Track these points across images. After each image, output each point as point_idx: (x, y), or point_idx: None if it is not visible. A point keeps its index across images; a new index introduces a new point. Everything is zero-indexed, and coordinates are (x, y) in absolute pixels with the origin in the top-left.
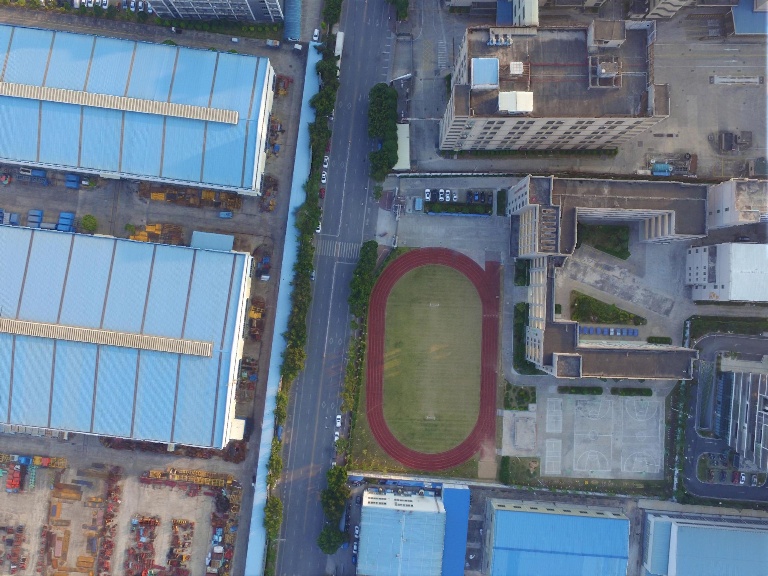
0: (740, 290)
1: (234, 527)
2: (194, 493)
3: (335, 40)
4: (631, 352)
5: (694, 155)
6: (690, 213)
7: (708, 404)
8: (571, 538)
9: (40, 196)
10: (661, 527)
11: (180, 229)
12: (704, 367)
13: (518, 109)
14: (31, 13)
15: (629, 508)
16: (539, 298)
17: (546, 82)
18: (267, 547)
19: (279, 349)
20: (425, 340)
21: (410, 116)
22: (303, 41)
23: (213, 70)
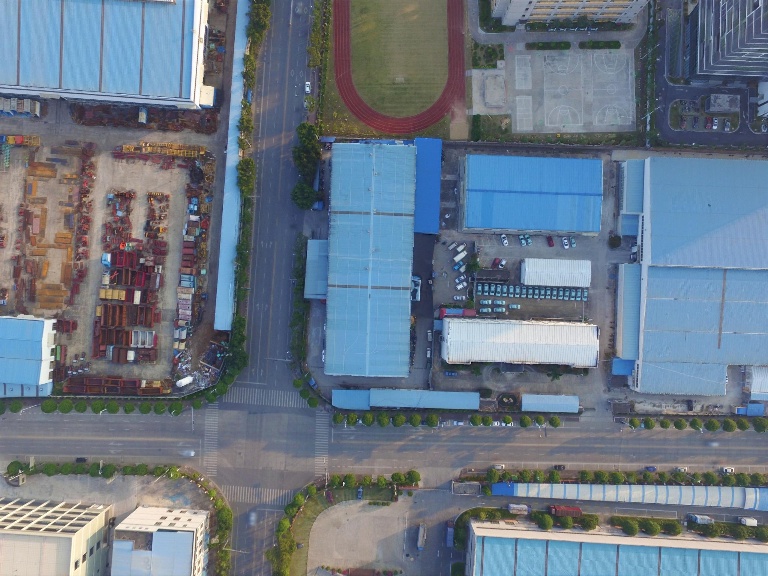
0: None
1: (209, 197)
2: (168, 166)
3: None
4: None
5: None
6: None
7: (677, 56)
8: (544, 178)
9: None
10: (634, 165)
11: None
12: (671, 15)
13: None
14: None
15: (603, 161)
16: None
17: None
18: (242, 213)
19: (244, 12)
20: (390, 5)
21: None
22: None
23: None
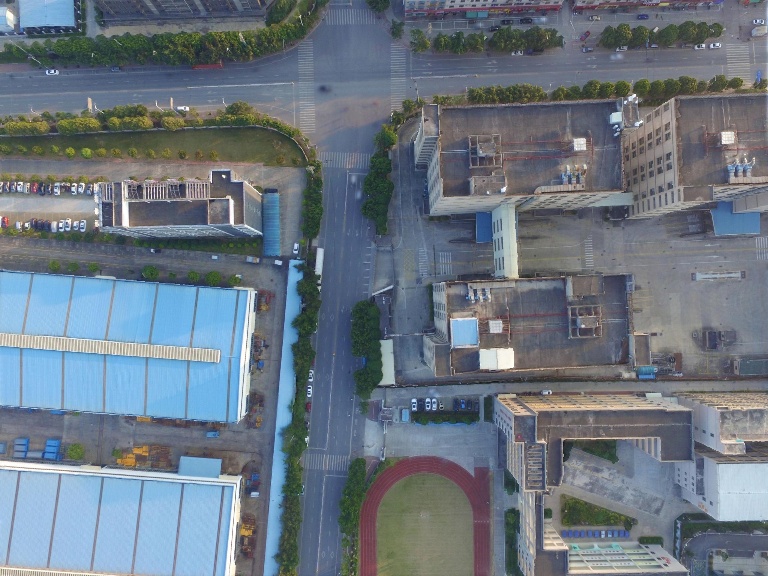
0: (728, 511)
1: None
2: None
3: (315, 257)
4: (622, 575)
5: (679, 354)
6: (676, 438)
7: None
8: None
9: (25, 423)
10: None
11: (167, 450)
12: (696, 566)
13: (499, 368)
14: (8, 239)
15: None
16: (529, 519)
17: (526, 333)
18: None
19: (271, 571)
20: (417, 549)
21: (393, 326)
22: (283, 254)
23: (193, 306)
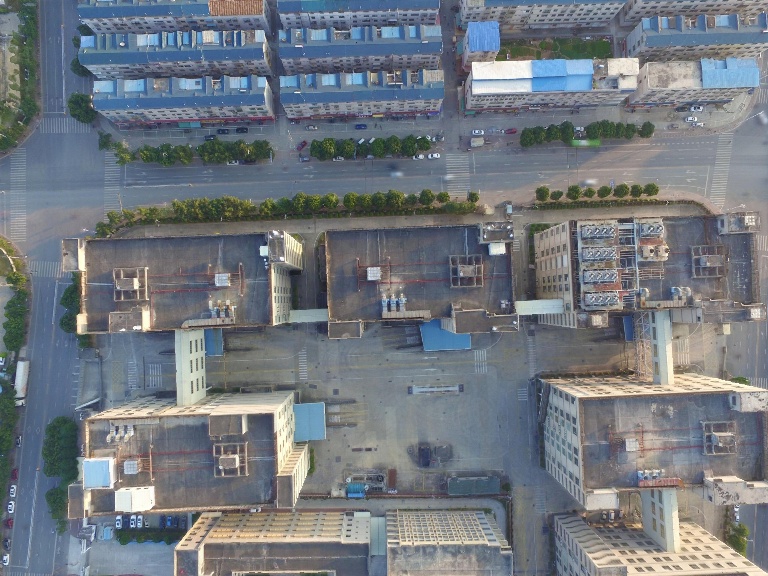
0: None
1: None
2: None
3: (15, 371)
4: None
5: (392, 471)
6: (353, 571)
7: None
8: None
9: None
10: None
11: None
12: None
13: (133, 510)
14: None
15: None
16: None
17: (171, 471)
18: None
19: None
20: None
21: None
22: None
23: None
